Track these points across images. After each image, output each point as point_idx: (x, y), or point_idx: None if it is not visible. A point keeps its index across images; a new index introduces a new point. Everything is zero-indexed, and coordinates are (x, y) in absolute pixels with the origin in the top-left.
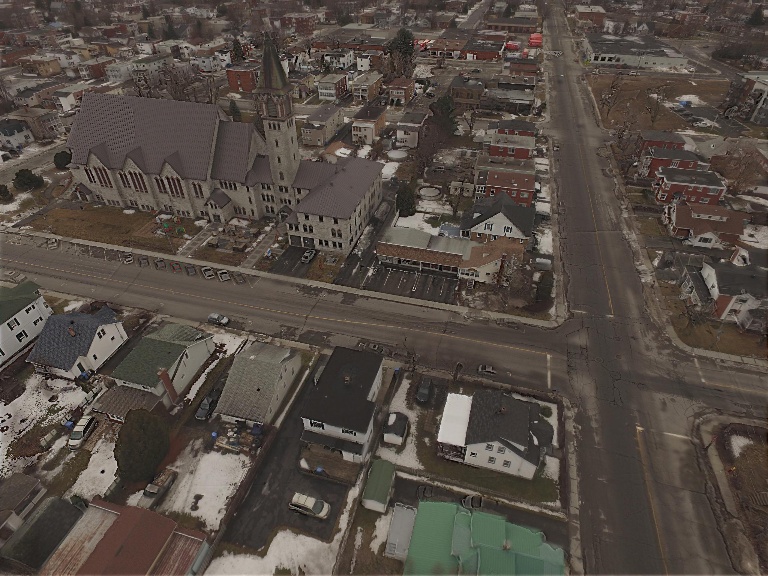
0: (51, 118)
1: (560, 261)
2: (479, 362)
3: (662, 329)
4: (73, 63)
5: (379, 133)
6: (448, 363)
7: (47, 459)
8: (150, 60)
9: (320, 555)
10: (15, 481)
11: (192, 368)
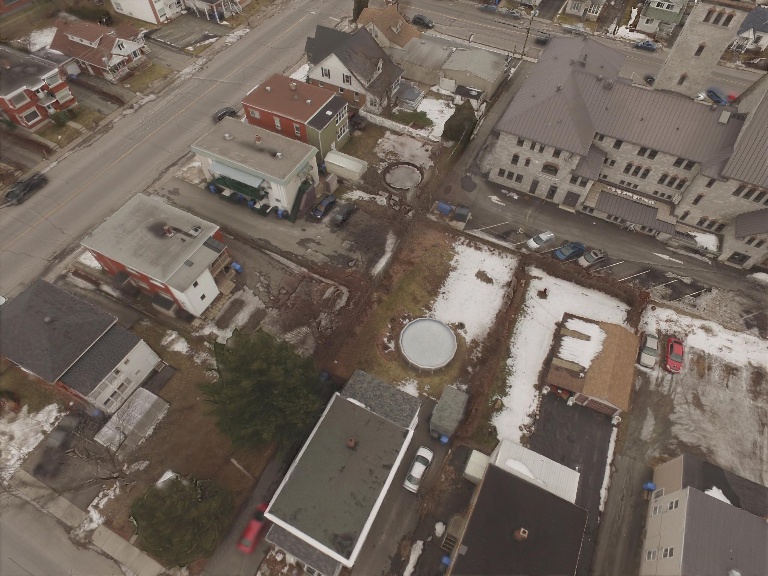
0: None
1: (305, 56)
2: (437, 3)
3: (284, 3)
4: None
5: None
6: (459, 5)
7: None
8: None
9: None
10: None
11: None
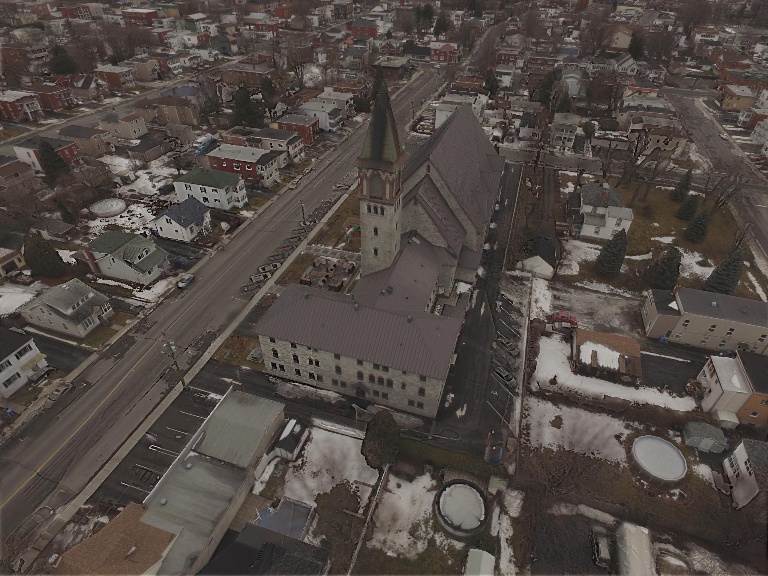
0: (567, 130)
1: None
2: None
3: None
4: None
5: None
6: None
7: (91, 237)
8: None
9: None
10: (65, 226)
11: (122, 273)
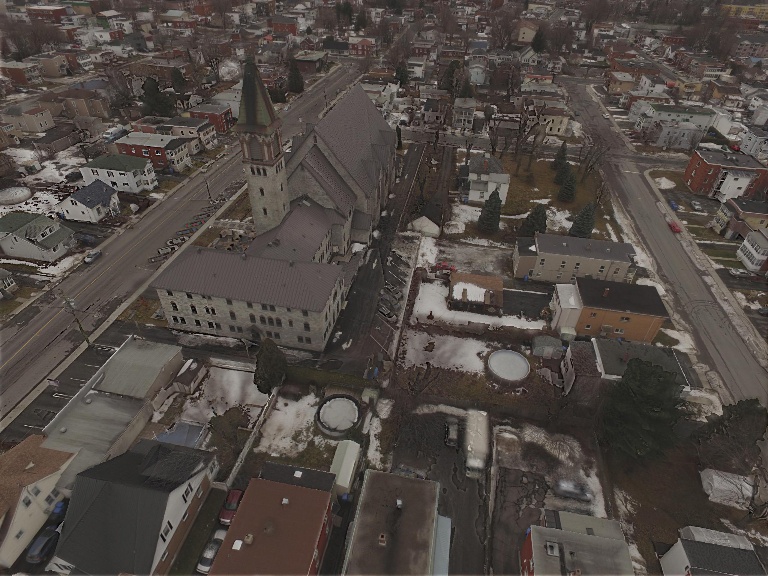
0: (465, 112)
1: None
2: None
3: None
4: (652, 91)
5: (601, 334)
6: None
7: None
8: (667, 109)
9: None
10: None
11: (26, 253)
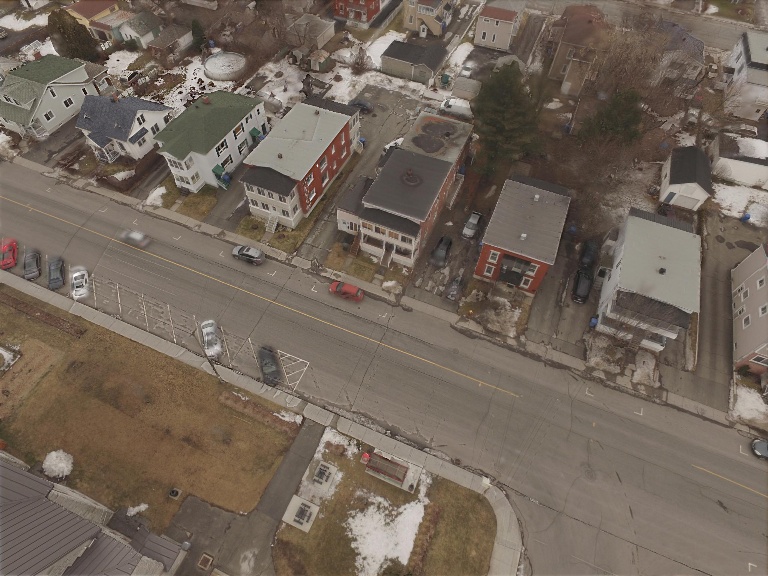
0: None
1: None
2: None
3: None
4: None
5: None
6: None
7: None
8: None
9: (4, 22)
10: (159, 41)
11: None
